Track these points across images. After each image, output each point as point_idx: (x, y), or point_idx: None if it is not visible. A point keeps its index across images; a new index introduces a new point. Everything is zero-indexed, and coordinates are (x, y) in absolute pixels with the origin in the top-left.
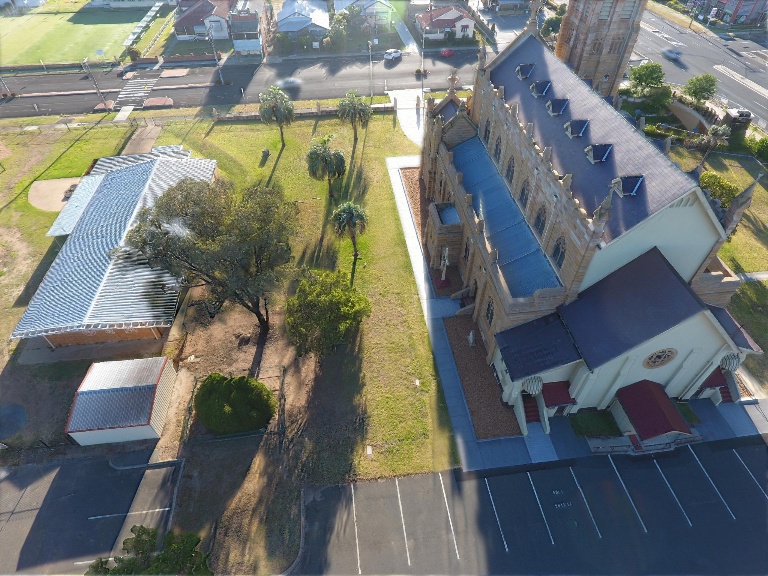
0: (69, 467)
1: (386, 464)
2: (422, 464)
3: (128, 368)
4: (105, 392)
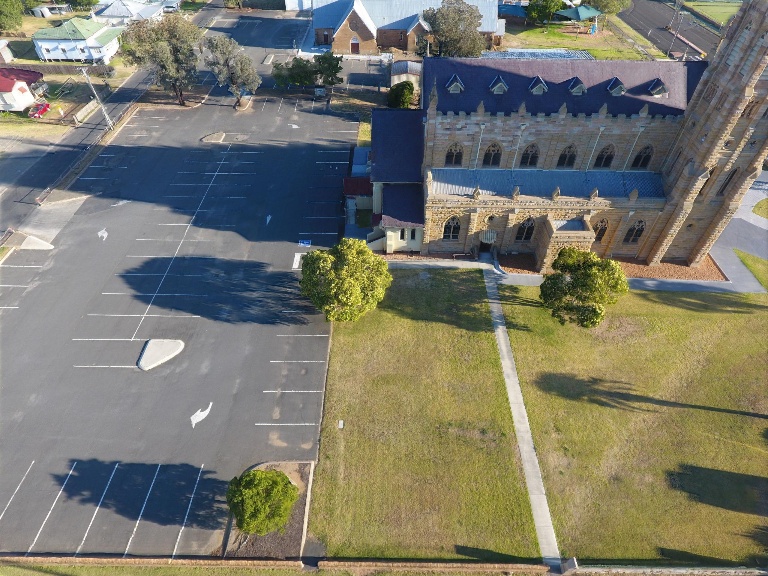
0: (384, 75)
1: (365, 130)
2: (362, 137)
3: (418, 69)
4: (406, 65)
